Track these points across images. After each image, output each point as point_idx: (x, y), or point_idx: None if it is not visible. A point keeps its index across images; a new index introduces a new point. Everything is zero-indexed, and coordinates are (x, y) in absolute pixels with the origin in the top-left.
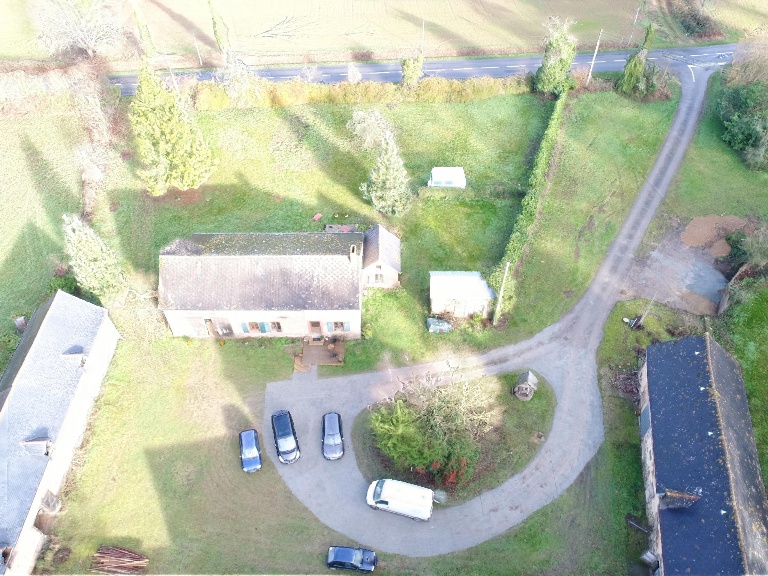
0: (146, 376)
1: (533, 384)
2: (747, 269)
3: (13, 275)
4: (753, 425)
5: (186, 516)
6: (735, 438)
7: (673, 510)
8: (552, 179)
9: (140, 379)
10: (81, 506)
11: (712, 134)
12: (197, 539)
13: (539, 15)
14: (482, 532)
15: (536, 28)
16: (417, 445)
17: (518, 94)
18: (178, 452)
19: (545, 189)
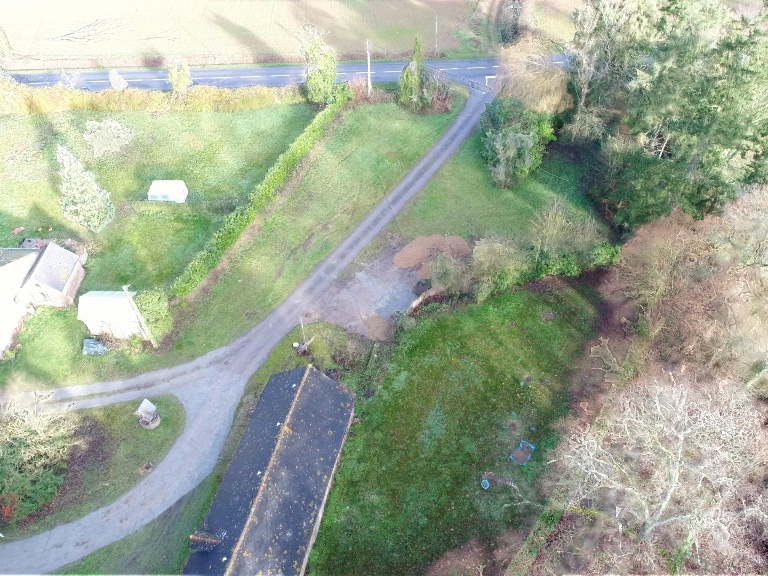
0: None
1: (146, 413)
2: (437, 293)
3: None
4: (362, 460)
5: None
6: (290, 478)
7: (199, 553)
8: (288, 194)
9: None
10: None
11: (475, 149)
12: None
13: (358, 21)
14: (33, 569)
15: (348, 35)
16: None
17: (294, 104)
18: None
19: (273, 205)
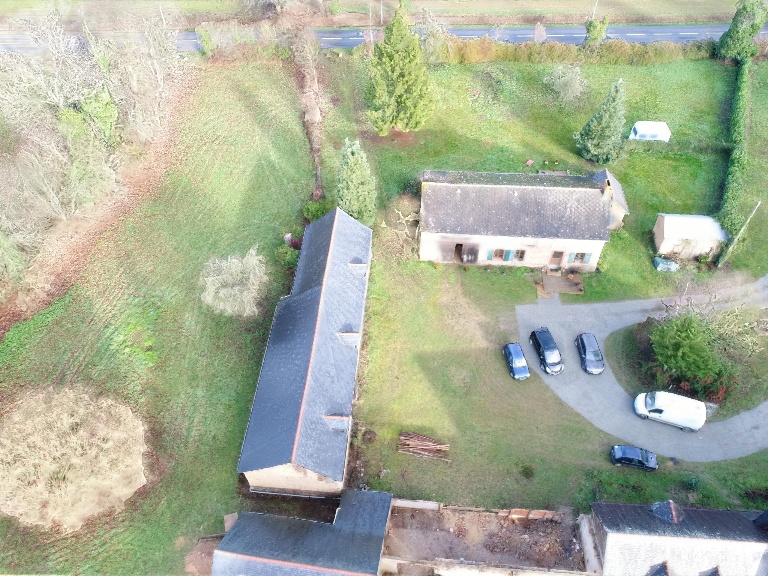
0: (403, 293)
1: None
2: None
3: (262, 200)
4: None
5: (470, 413)
6: None
7: None
8: (747, 139)
9: (398, 295)
10: (374, 398)
11: None
12: (485, 432)
13: None
14: (749, 445)
15: None
16: (706, 355)
17: (697, 59)
18: (449, 359)
19: (744, 147)
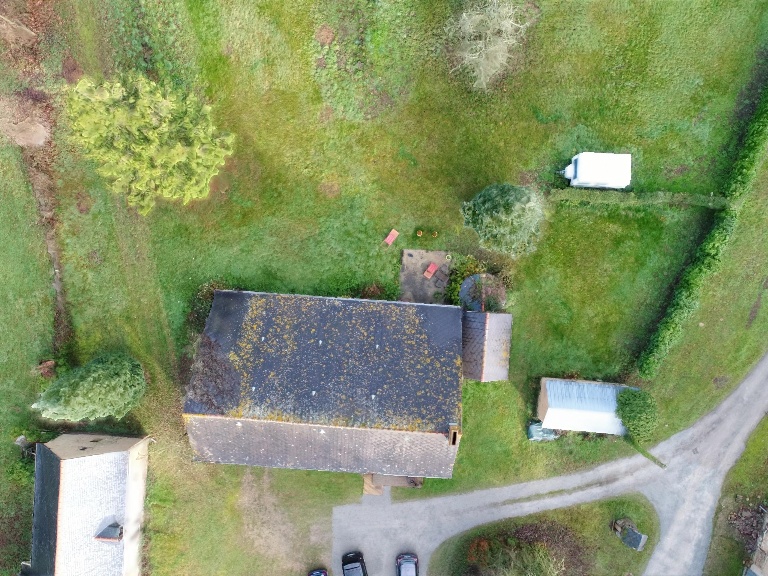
0: (192, 493)
1: (642, 547)
2: None
3: None
4: None
5: None
6: None
7: None
8: (766, 152)
9: (186, 497)
10: None
11: None
12: None
13: None
14: None
15: None
16: None
17: None
18: None
19: None
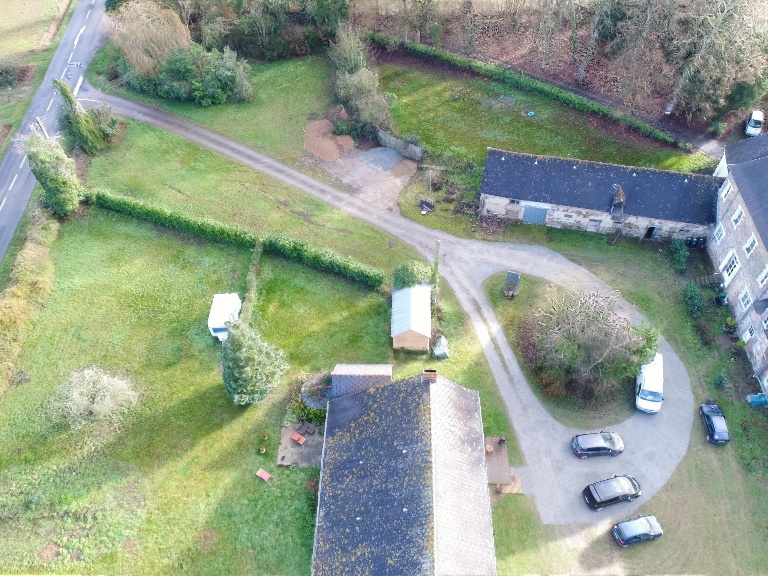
0: None
1: None
2: None
3: None
4: None
5: None
6: None
7: (626, 205)
8: None
9: None
10: None
11: (194, 111)
12: None
13: None
14: None
15: None
16: None
17: (58, 236)
18: None
19: None
